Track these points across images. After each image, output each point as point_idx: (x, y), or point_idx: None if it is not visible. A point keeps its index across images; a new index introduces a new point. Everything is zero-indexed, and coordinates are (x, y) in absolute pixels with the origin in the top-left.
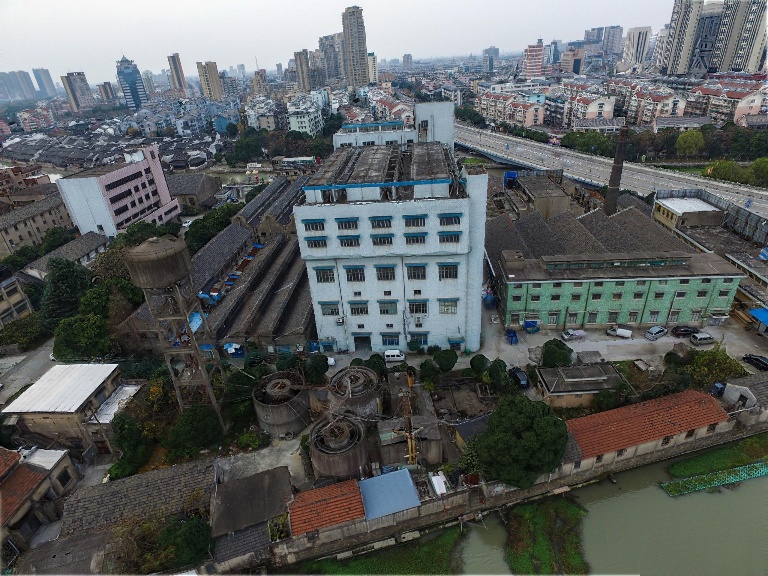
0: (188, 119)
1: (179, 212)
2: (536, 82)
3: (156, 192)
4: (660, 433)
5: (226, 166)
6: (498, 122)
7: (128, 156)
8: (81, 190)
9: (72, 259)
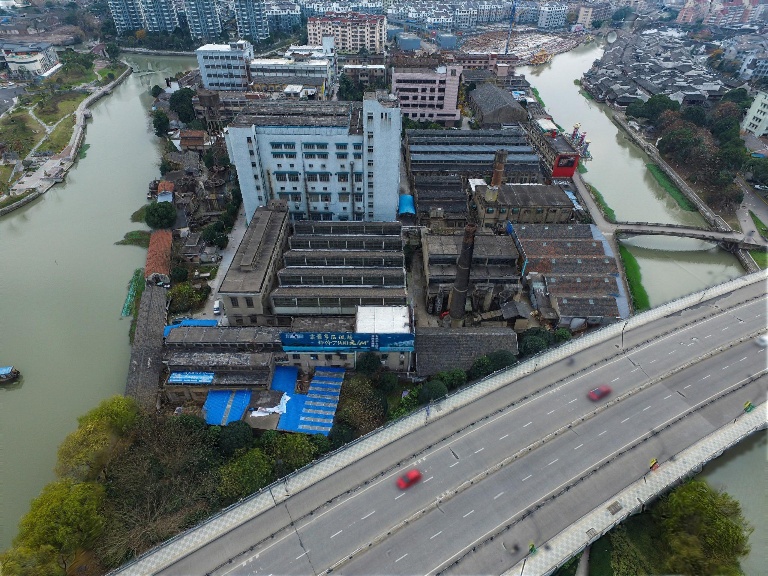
0: (764, 57)
1: (455, 119)
2: None
3: (443, 98)
4: (149, 255)
5: (632, 116)
6: None
7: None
8: None
9: None
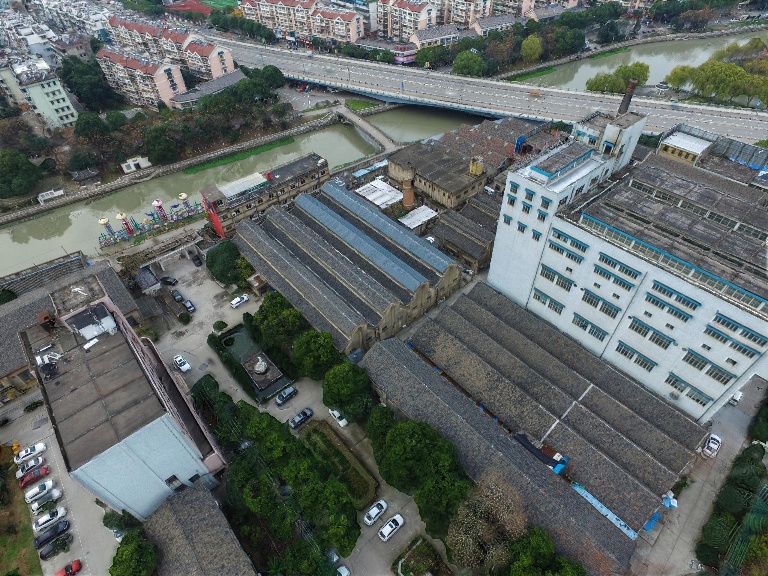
0: None
1: None
2: None
3: None
4: None
5: None
6: (299, 35)
7: (91, 329)
8: (131, 454)
9: (246, 568)
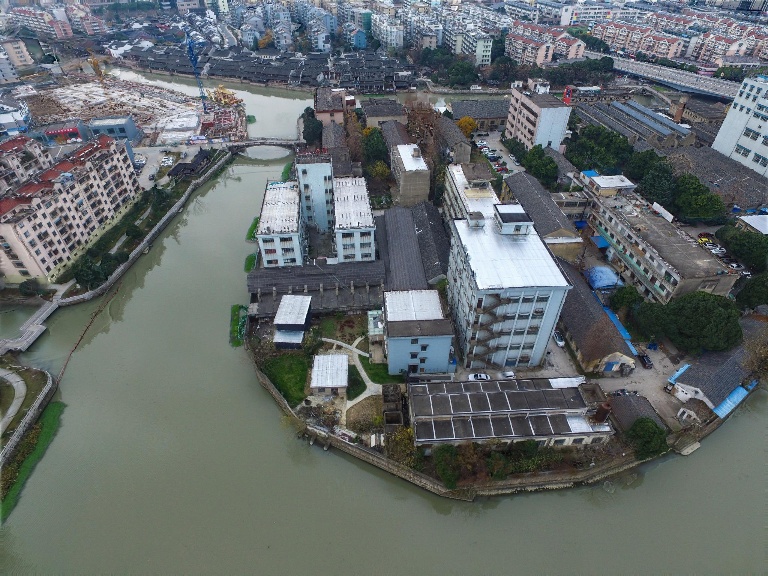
0: (328, 33)
1: None
2: (596, 4)
3: None
4: None
5: (443, 87)
6: (628, 51)
7: (543, 88)
8: (553, 116)
9: None
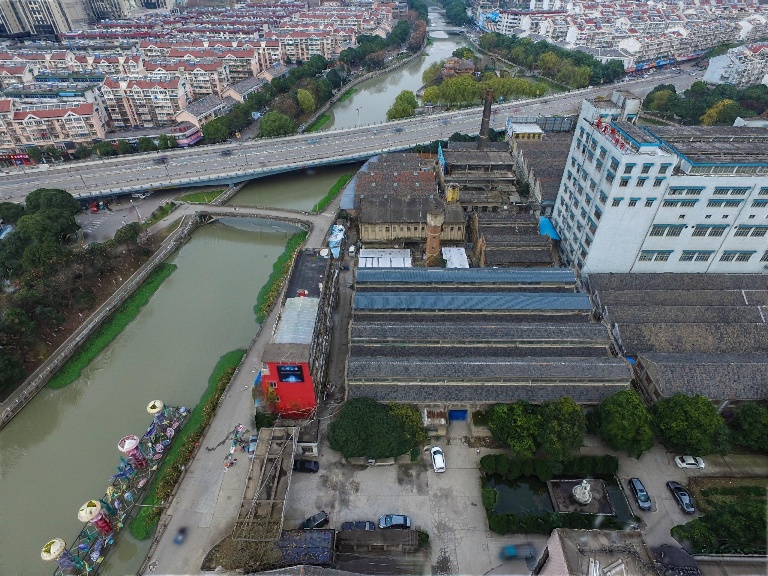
0: None
1: None
2: None
3: None
4: None
5: None
6: None
7: None
8: None
9: None
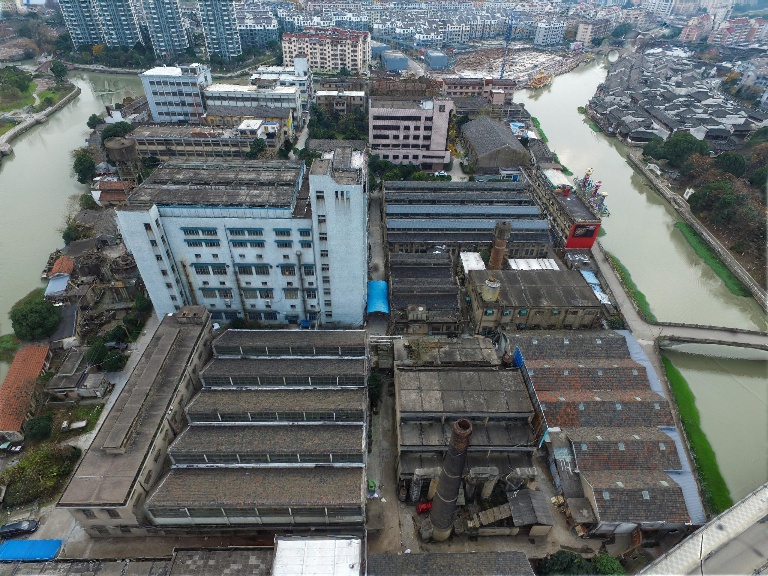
0: None
1: (445, 162)
2: None
3: (430, 138)
4: (1, 392)
5: None
6: None
7: None
8: None
9: None
